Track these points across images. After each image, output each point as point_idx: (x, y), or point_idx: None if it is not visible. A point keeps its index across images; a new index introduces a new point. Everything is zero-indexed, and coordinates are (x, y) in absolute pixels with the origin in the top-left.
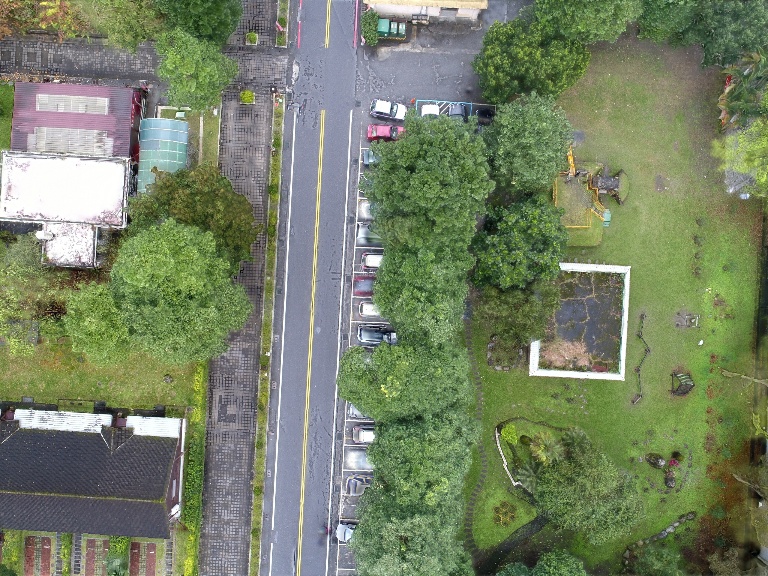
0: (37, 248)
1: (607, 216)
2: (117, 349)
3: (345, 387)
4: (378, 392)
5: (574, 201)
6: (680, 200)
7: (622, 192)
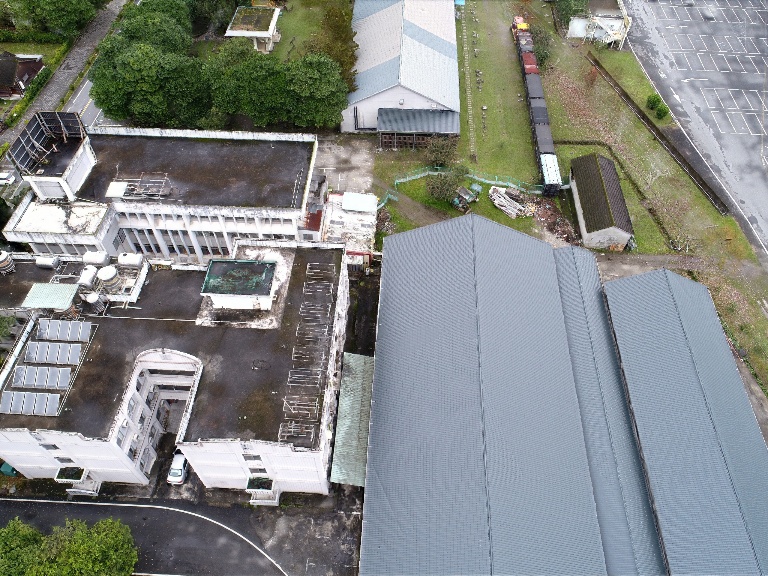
0: (4, 2)
1: (280, 12)
2: (24, 4)
3: (126, 10)
4: (139, 6)
5: (263, 4)
6: (317, 11)
7: (288, 6)
